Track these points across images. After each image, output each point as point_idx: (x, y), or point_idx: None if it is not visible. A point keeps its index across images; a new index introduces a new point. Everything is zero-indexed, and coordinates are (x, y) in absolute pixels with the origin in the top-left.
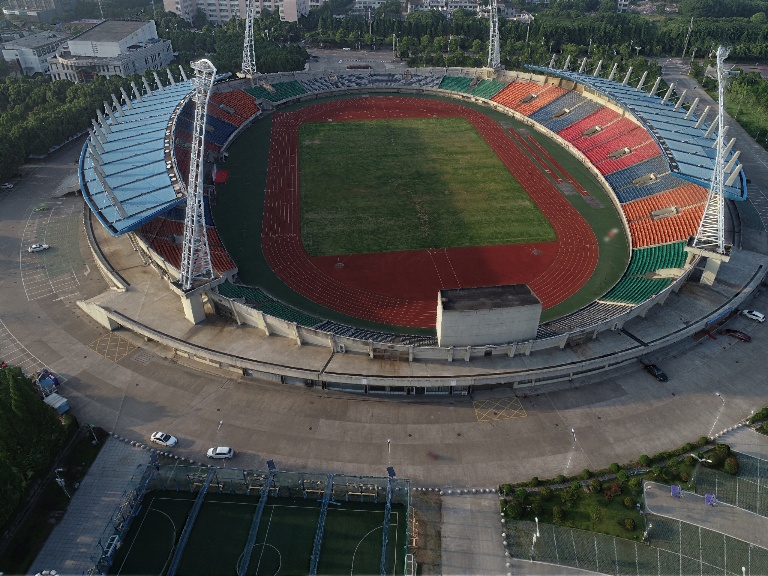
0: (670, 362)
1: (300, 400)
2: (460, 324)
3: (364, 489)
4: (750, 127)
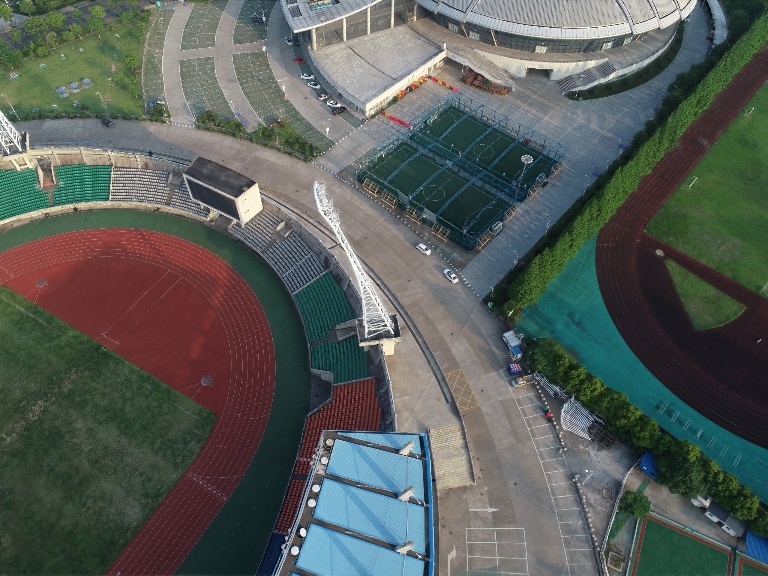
0: None
1: None
2: None
3: None
4: None
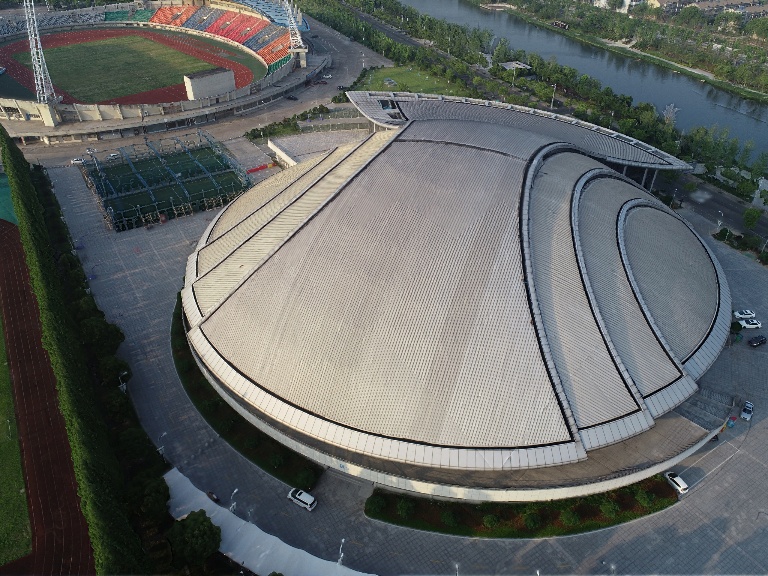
0: (297, 95)
1: (136, 140)
2: (200, 86)
3: (189, 143)
4: (314, 15)
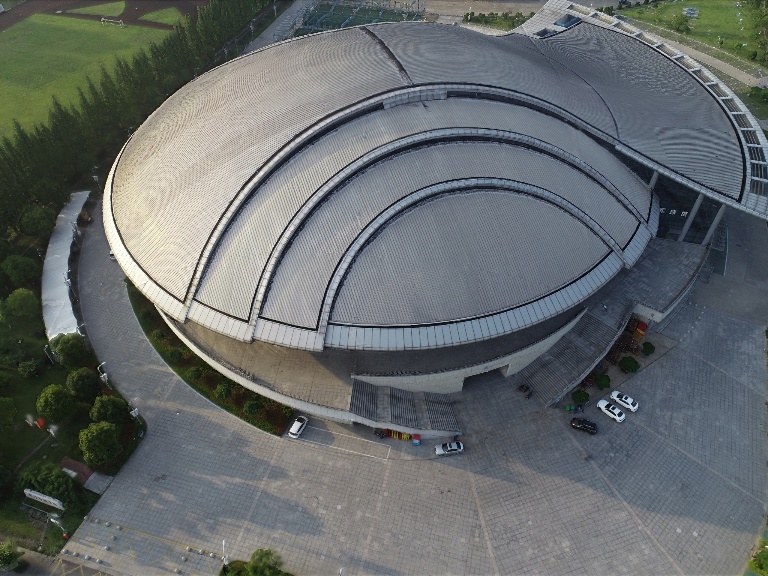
0: None
1: None
2: None
3: (408, 6)
4: None
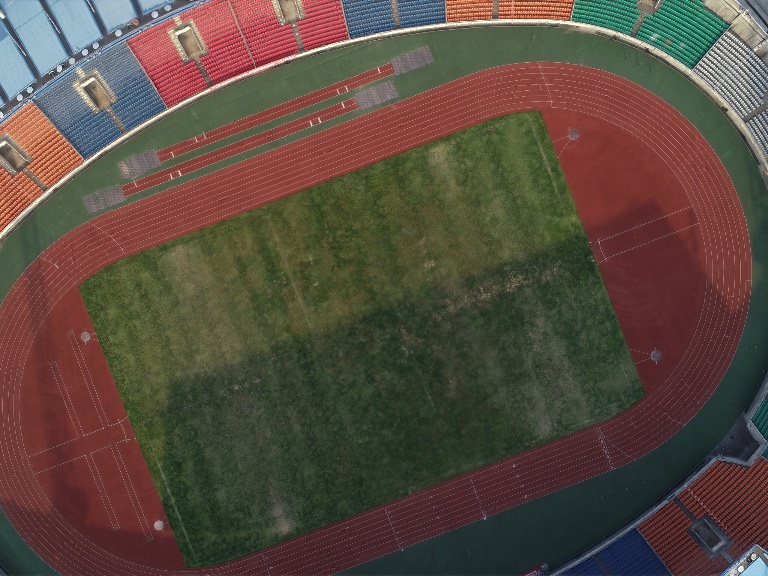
0: None
1: None
2: None
3: None
4: None
